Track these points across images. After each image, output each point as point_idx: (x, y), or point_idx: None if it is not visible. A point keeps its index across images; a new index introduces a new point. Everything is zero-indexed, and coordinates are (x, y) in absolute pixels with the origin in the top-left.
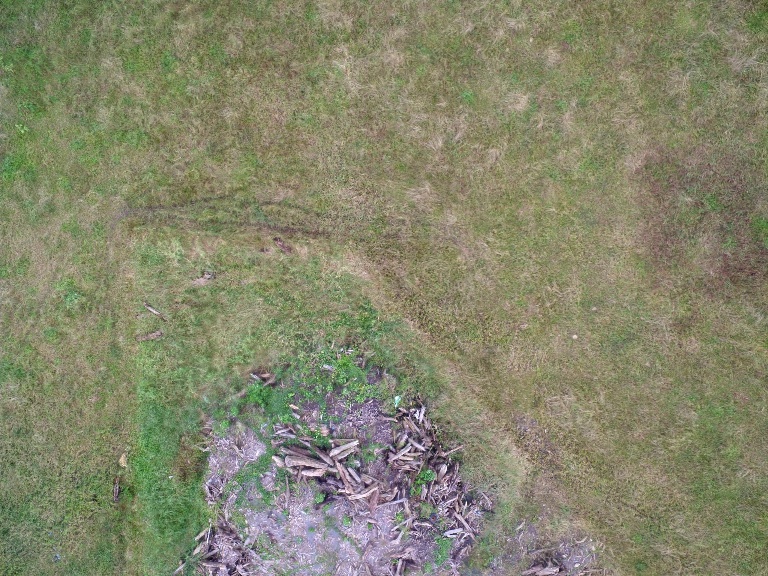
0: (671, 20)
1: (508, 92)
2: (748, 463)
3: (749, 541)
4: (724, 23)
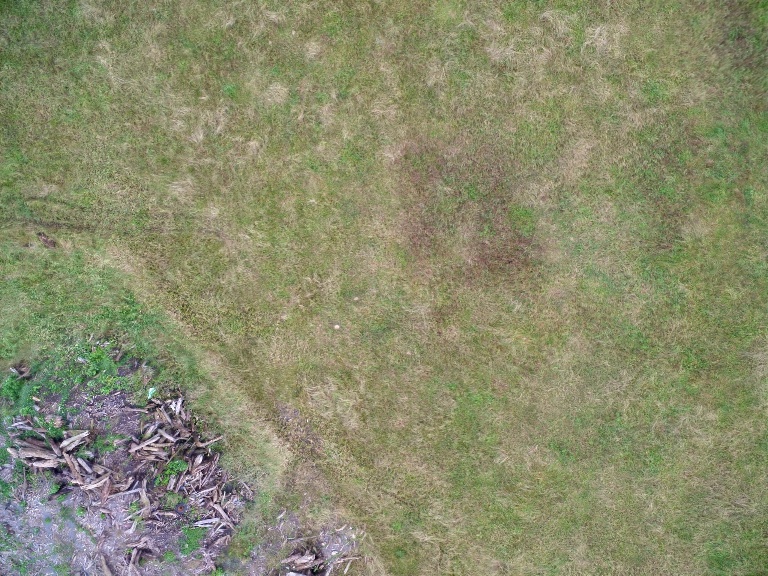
0: (430, 11)
1: (270, 85)
2: (507, 449)
3: (507, 527)
4: (481, 13)
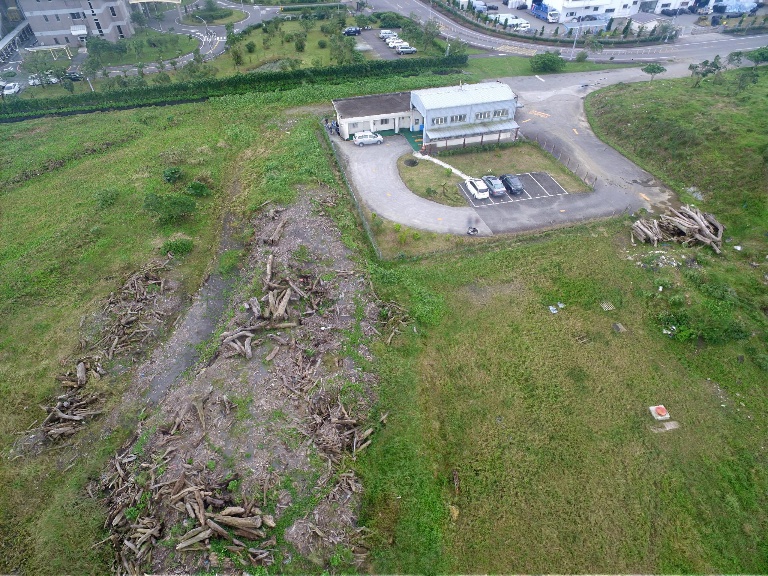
0: None
1: None
2: None
3: None
4: None
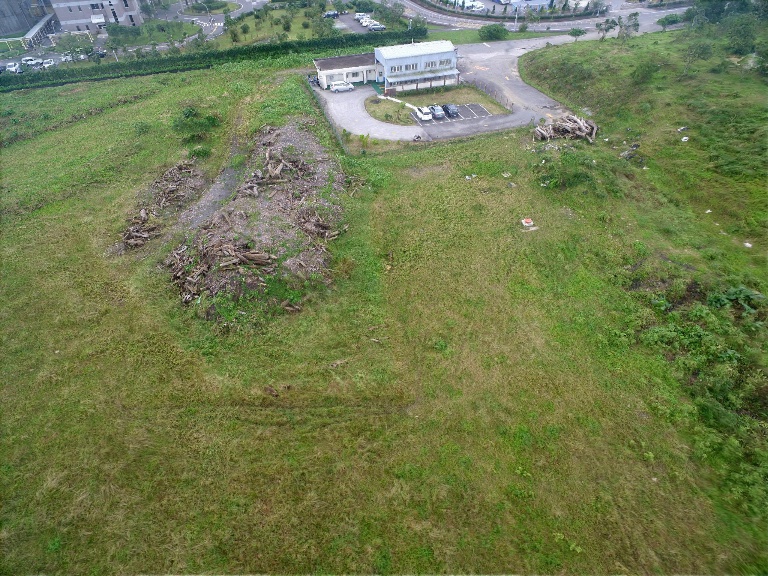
0: None
1: (6, 554)
2: None
3: (8, 263)
4: None
